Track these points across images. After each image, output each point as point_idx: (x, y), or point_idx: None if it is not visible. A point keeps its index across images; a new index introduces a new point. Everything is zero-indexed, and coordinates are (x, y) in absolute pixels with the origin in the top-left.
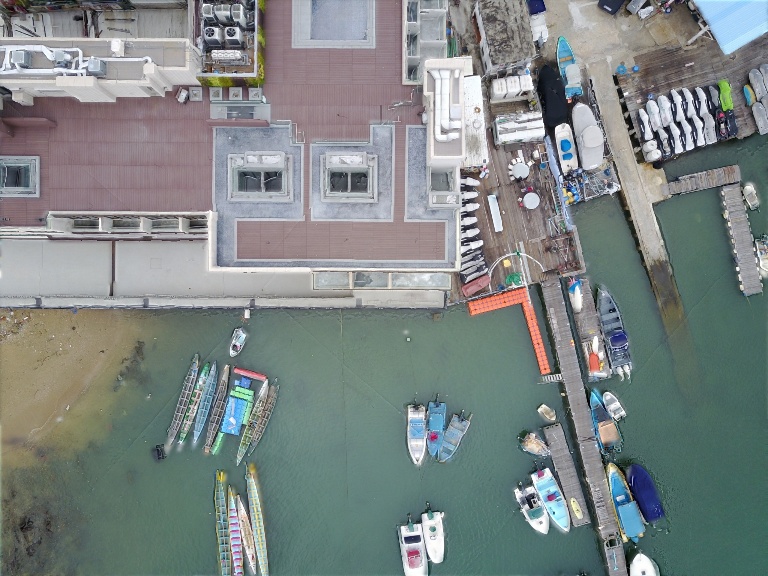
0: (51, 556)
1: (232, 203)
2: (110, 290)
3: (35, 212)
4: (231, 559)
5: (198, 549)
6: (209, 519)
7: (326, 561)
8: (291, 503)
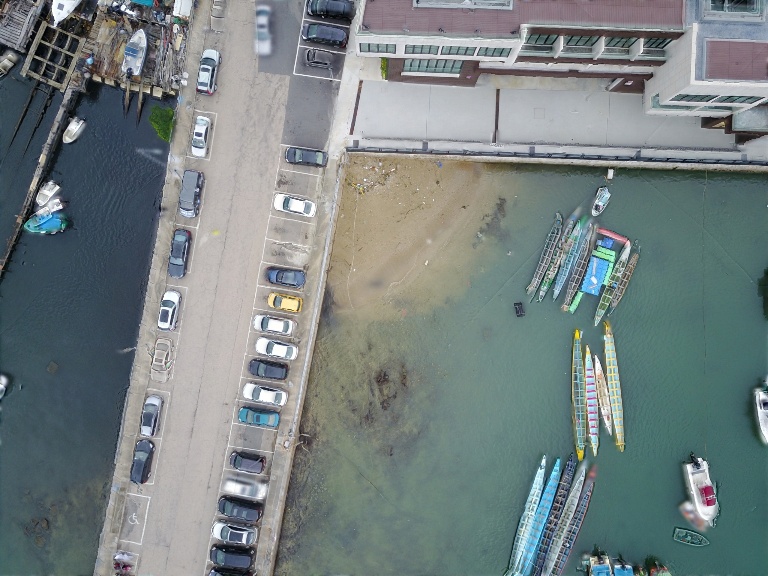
0: (405, 411)
1: (702, 23)
2: (493, 139)
3: (505, 25)
4: (586, 420)
5: (553, 409)
6: (564, 379)
7: (680, 425)
8: (645, 366)
